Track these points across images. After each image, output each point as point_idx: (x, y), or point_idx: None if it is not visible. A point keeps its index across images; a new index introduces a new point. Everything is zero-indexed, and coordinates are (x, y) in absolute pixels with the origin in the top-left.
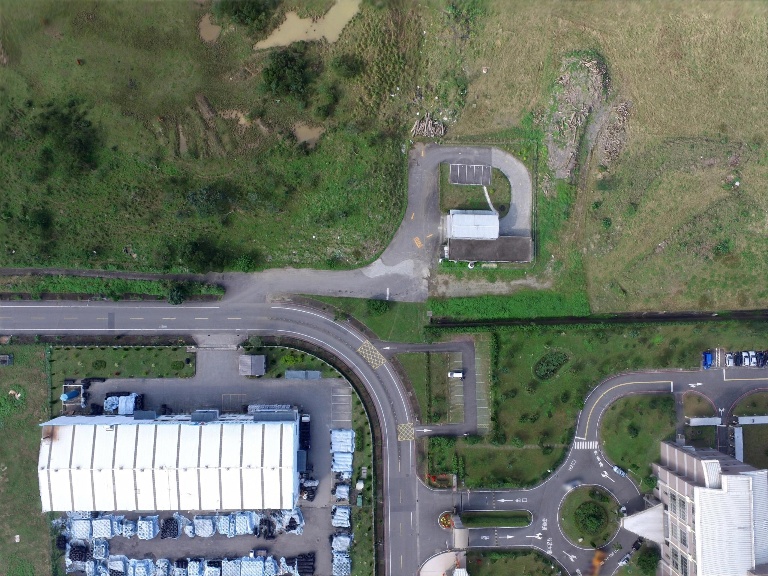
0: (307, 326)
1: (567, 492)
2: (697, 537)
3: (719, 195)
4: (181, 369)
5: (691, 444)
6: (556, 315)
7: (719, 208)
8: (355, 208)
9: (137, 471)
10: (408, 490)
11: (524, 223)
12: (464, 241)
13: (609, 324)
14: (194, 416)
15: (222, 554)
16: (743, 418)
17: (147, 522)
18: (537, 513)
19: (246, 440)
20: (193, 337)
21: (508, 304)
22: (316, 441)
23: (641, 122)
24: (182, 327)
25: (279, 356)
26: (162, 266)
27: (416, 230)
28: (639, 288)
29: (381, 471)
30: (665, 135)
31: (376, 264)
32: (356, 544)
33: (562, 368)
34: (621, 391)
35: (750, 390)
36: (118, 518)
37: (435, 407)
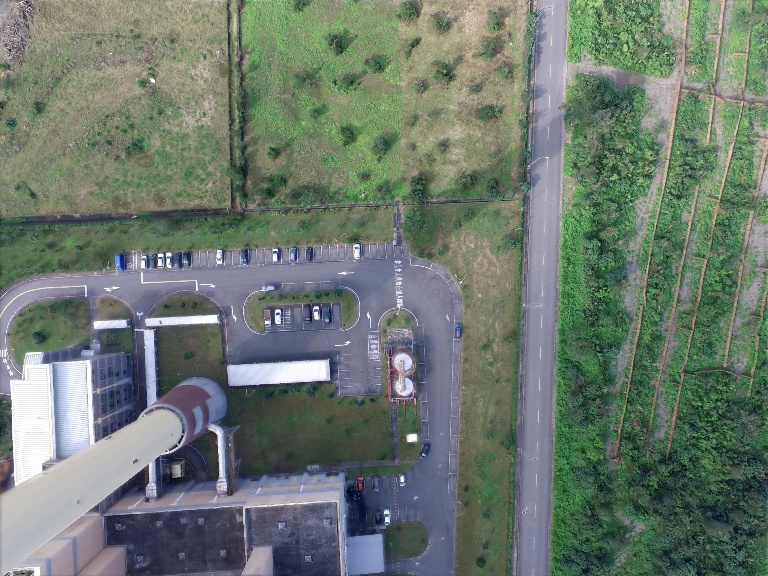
0: None
1: None
2: None
3: (134, 93)
4: None
5: (106, 349)
6: None
7: (131, 106)
8: None
9: None
10: None
11: None
12: None
13: (8, 227)
14: None
15: None
16: (150, 320)
17: None
18: None
19: None
20: None
21: None
22: None
23: (47, 18)
24: None
25: None
26: None
27: None
28: (47, 190)
29: None
30: (73, 31)
31: None
32: None
33: None
34: (31, 297)
35: (170, 293)
36: None
37: None
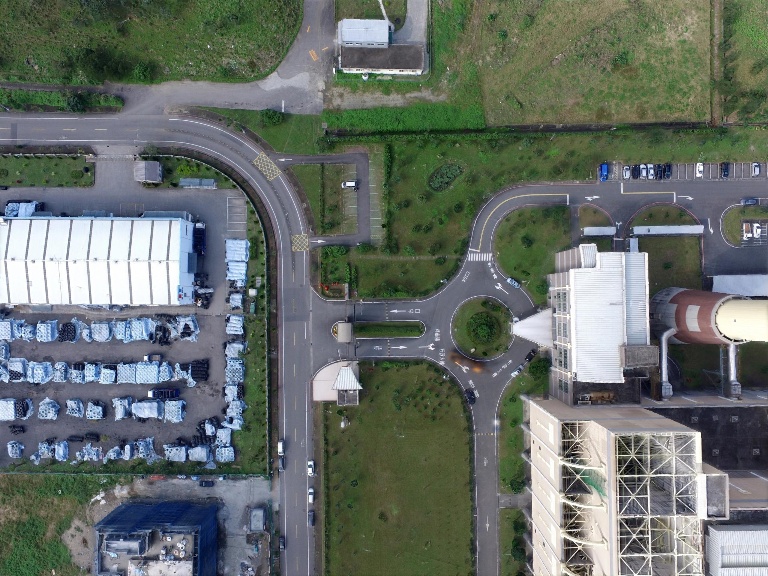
0: (204, 138)
1: (460, 303)
2: (572, 318)
3: (618, 7)
4: (80, 178)
5: None
6: (451, 127)
7: (618, 20)
8: (248, 15)
9: (28, 262)
10: (302, 300)
11: (419, 36)
12: (356, 49)
13: (502, 133)
14: (86, 213)
15: (118, 359)
16: (638, 228)
17: (45, 324)
18: (430, 324)
19: (135, 235)
20: (92, 148)
21: (402, 115)
22: (211, 250)
23: None
24: (82, 138)
25: (176, 166)
26: (62, 76)
27: (312, 43)
28: (535, 100)
29: (275, 281)
30: None
31: (272, 77)
32: (249, 352)
33: (456, 180)
34: (516, 203)
35: (648, 204)
36: (18, 322)
37: (329, 217)
